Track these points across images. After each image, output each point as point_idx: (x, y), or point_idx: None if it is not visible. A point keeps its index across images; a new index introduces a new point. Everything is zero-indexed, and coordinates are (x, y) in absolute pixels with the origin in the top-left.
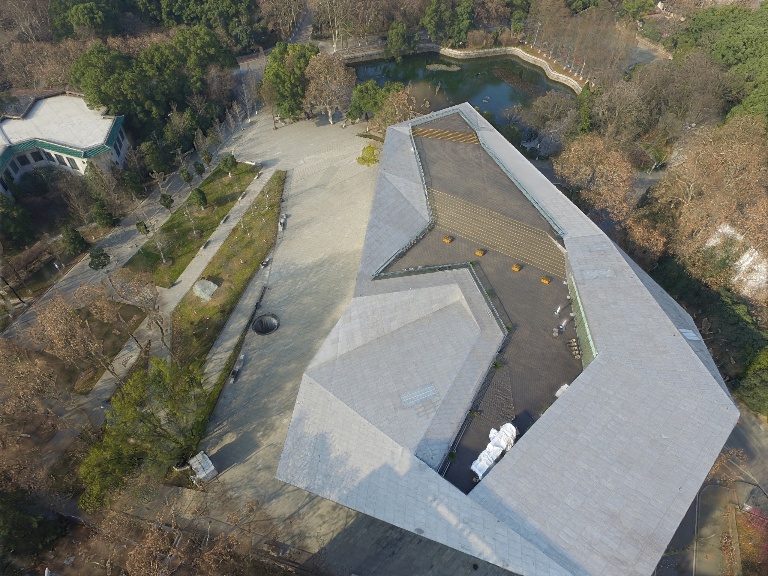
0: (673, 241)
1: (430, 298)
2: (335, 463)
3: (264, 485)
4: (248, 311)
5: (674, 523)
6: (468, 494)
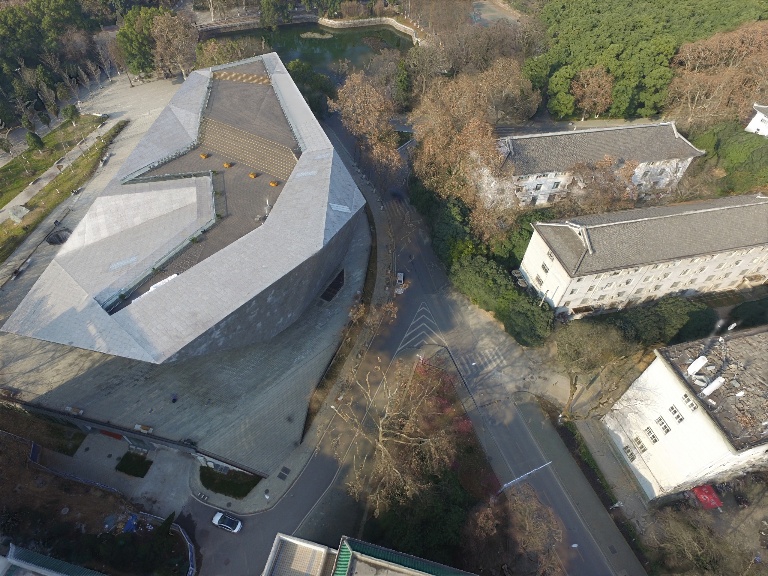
0: (416, 160)
1: (170, 198)
2: (42, 313)
3: (15, 350)
4: (49, 228)
5: (228, 312)
6: (111, 315)
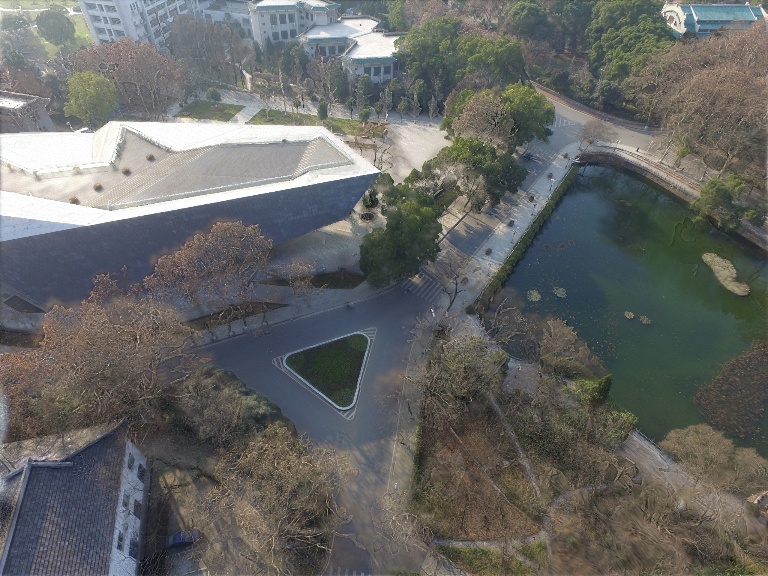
0: None
1: None
2: None
3: None
4: None
5: None
6: None
